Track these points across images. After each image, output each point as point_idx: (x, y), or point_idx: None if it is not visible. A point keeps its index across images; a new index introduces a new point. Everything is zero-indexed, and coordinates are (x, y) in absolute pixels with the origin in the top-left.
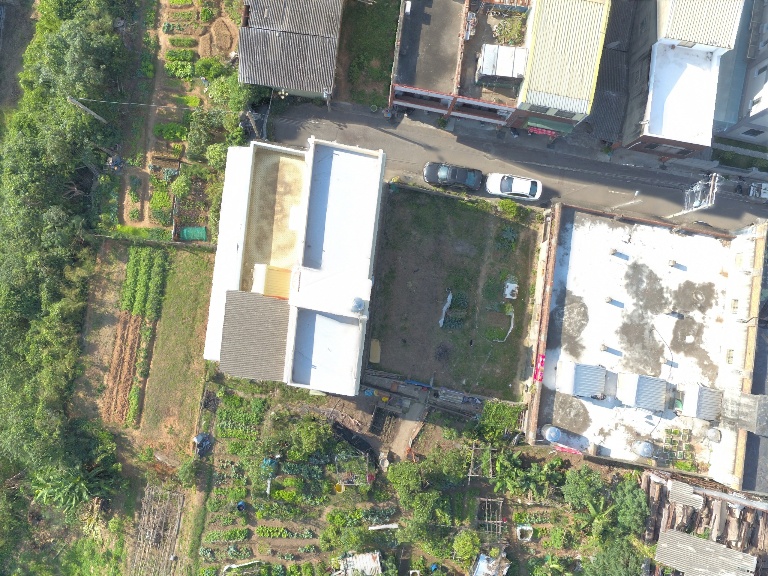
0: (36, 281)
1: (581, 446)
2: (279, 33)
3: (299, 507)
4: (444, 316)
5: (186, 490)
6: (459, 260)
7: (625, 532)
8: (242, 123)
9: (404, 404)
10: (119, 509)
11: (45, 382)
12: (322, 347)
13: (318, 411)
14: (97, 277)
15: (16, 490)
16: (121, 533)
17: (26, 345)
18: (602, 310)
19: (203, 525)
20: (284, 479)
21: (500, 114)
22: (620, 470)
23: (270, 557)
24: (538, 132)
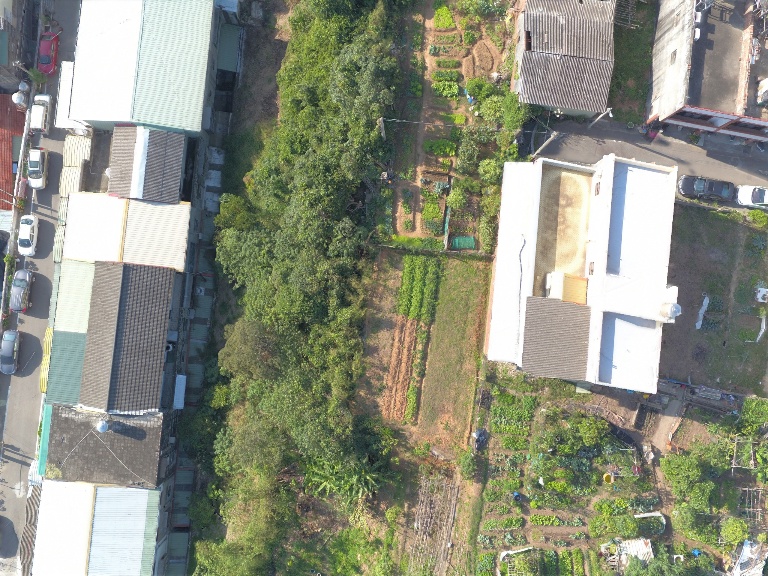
0: (324, 288)
1: None
2: (560, 57)
3: (568, 497)
4: (702, 319)
5: (460, 482)
6: (713, 266)
7: None
8: (517, 140)
9: (663, 401)
10: (387, 500)
11: (333, 382)
12: (621, 349)
13: (584, 408)
14: (375, 284)
15: (285, 483)
16: None
17: (310, 348)
18: None
19: (481, 514)
20: (554, 471)
21: (767, 131)
22: None
23: (542, 544)
24: None
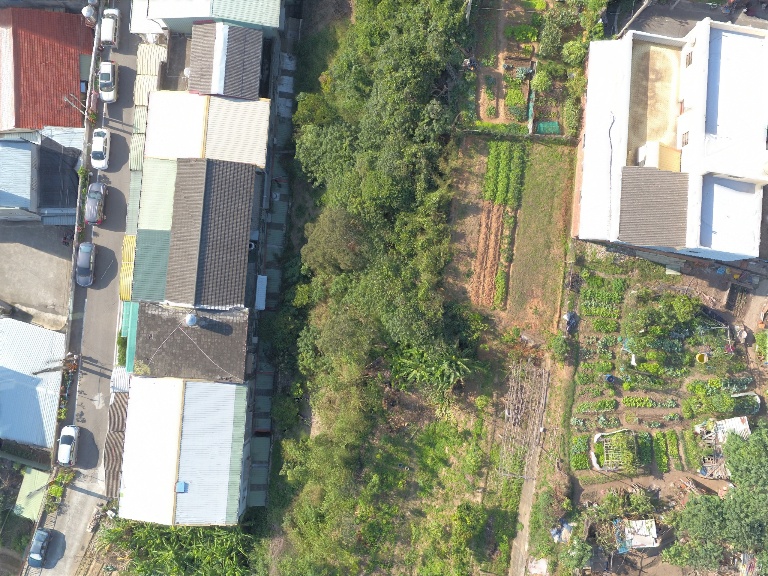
0: (411, 173)
1: None
2: None
3: (661, 379)
4: None
5: (551, 367)
6: None
7: None
8: (601, 19)
9: (753, 281)
10: (474, 391)
11: (422, 267)
12: (721, 214)
13: (674, 289)
14: (460, 170)
15: (370, 378)
16: (480, 412)
17: (396, 236)
18: None
19: (573, 397)
20: (646, 353)
21: None
22: None
23: (636, 426)
24: None
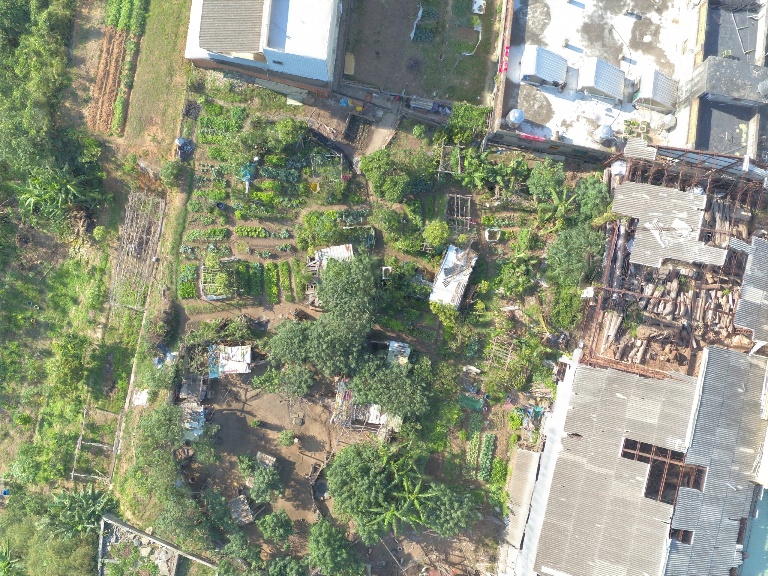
0: None
1: (544, 136)
2: None
3: (276, 209)
4: (415, 28)
5: (168, 196)
6: None
7: (587, 218)
8: None
9: (377, 114)
10: None
11: (33, 88)
12: (296, 20)
13: (295, 120)
14: None
15: (5, 215)
16: (105, 247)
17: (15, 59)
18: (564, 11)
19: (184, 224)
20: (262, 182)
21: None
22: (583, 175)
23: (248, 256)
24: None
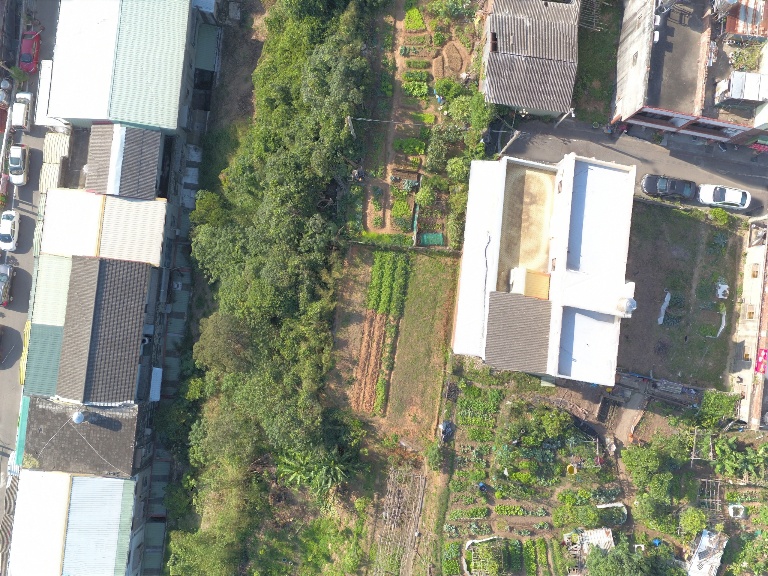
0: (295, 283)
1: None
2: (525, 58)
3: (533, 488)
4: (664, 314)
5: (428, 473)
6: (675, 263)
7: None
8: (483, 139)
9: (625, 394)
10: (357, 491)
11: (303, 375)
12: (581, 342)
13: (548, 401)
14: (345, 279)
15: (258, 474)
16: None
17: (281, 341)
18: None
19: (447, 504)
20: (519, 462)
21: (726, 132)
22: None
23: (507, 533)
24: (759, 148)
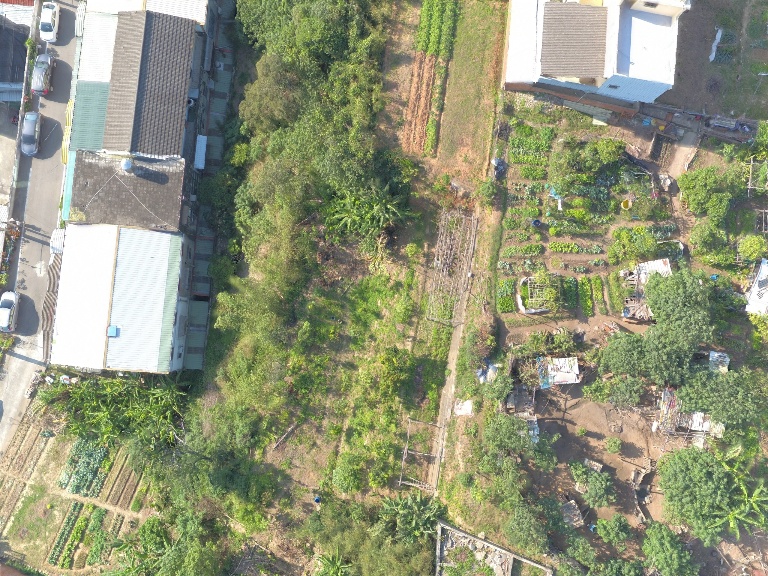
0: (344, 21)
1: None
2: None
3: (587, 225)
4: (716, 50)
5: (480, 214)
6: (725, 2)
7: None
8: None
9: (678, 133)
10: (406, 244)
11: (354, 112)
12: (638, 46)
13: (600, 139)
14: (393, 22)
15: None
16: (411, 263)
17: (330, 84)
18: None
19: (500, 241)
20: (573, 200)
21: None
22: None
23: (562, 271)
24: None
